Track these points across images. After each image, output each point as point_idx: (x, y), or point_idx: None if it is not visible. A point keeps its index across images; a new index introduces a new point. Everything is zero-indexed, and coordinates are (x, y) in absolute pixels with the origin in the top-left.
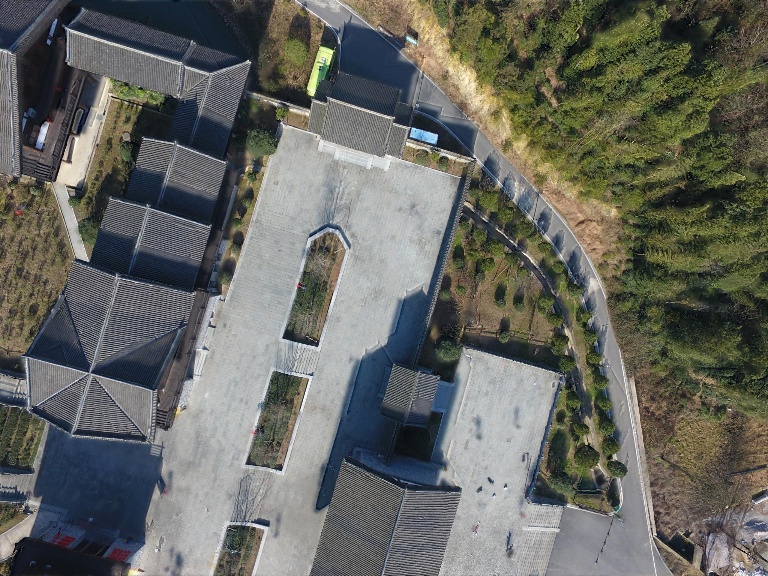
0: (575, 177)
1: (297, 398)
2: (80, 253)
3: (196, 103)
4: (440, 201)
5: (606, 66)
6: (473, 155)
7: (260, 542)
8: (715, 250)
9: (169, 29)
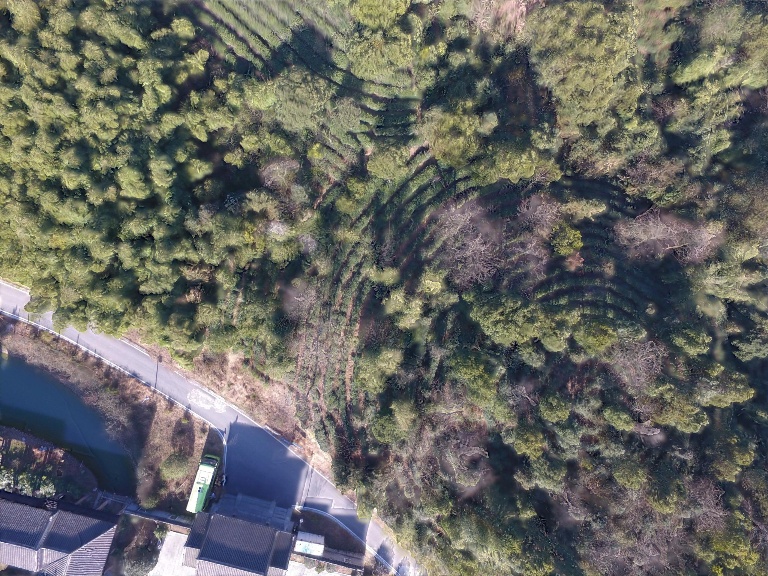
0: None
1: None
2: None
3: None
4: None
5: (477, 545)
6: (365, 544)
7: None
8: None
9: (48, 434)
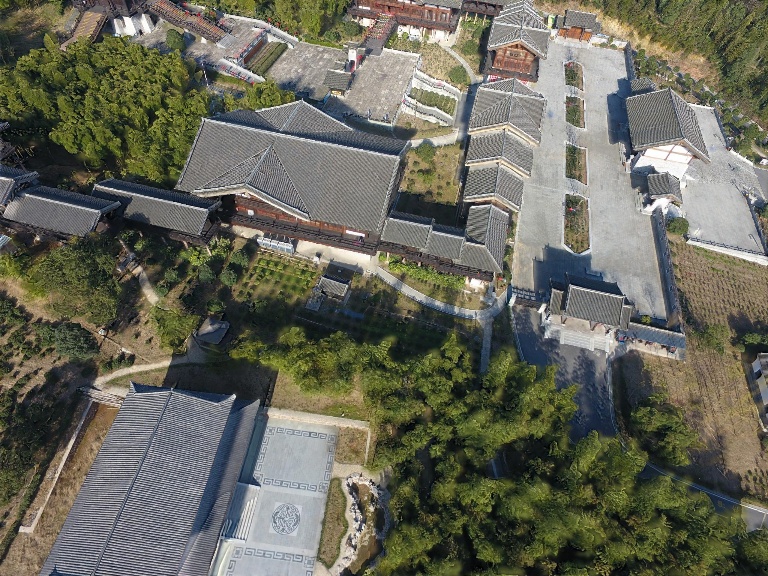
0: (677, 47)
1: None
2: (460, 59)
3: None
4: (618, 57)
5: None
6: None
7: (585, 153)
8: (759, 46)
9: None
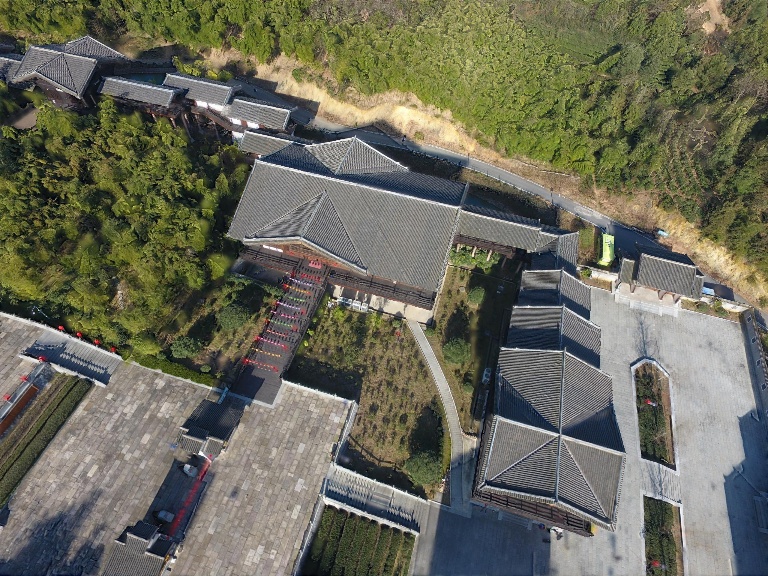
0: None
1: (673, 531)
2: (437, 373)
3: (551, 254)
4: (731, 340)
5: None
6: None
7: None
8: None
9: None
